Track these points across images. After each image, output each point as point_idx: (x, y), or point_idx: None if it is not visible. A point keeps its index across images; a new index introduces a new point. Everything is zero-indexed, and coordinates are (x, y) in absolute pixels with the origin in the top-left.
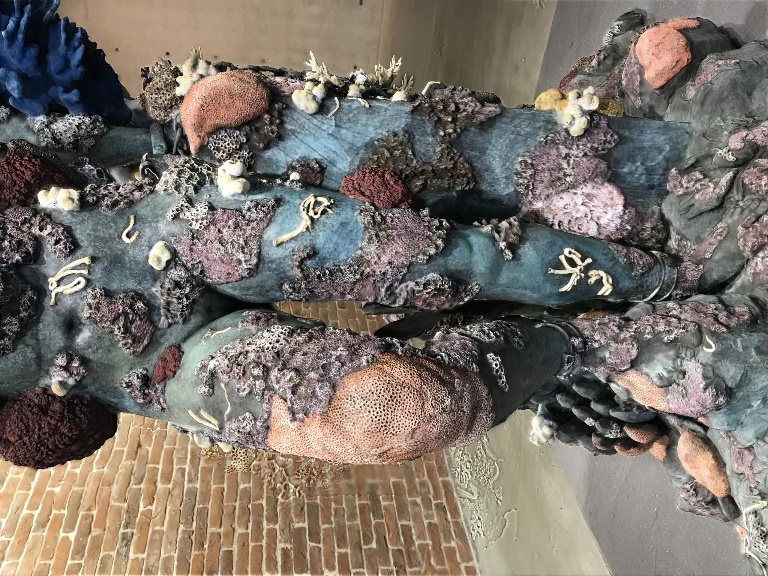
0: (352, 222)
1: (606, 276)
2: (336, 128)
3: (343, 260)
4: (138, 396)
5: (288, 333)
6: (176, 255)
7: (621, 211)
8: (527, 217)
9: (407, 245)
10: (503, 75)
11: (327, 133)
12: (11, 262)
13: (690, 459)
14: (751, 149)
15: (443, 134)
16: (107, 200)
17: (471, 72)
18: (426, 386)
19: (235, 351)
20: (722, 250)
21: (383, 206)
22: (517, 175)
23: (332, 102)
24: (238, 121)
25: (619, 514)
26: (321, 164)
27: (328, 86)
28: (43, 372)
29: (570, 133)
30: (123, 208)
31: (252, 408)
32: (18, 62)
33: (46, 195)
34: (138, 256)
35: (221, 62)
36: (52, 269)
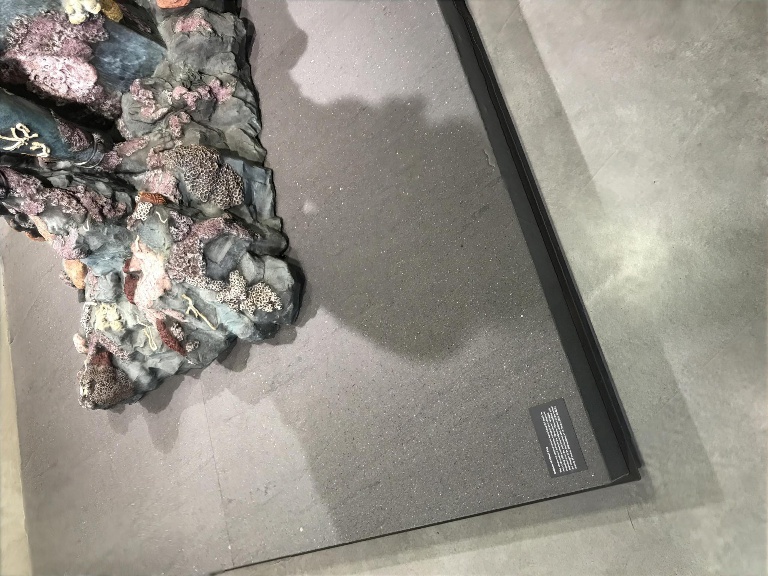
0: None
1: (46, 148)
2: None
3: None
4: None
5: None
6: None
7: (91, 86)
8: (8, 62)
9: None
10: None
11: None
12: None
13: (69, 263)
14: (183, 103)
15: None
16: None
17: None
18: None
19: None
20: (137, 156)
21: None
22: (10, 28)
23: None
24: None
25: (27, 256)
26: None
27: None
28: None
29: (69, 18)
30: None
31: None
32: None
33: None
34: None
35: None
36: None
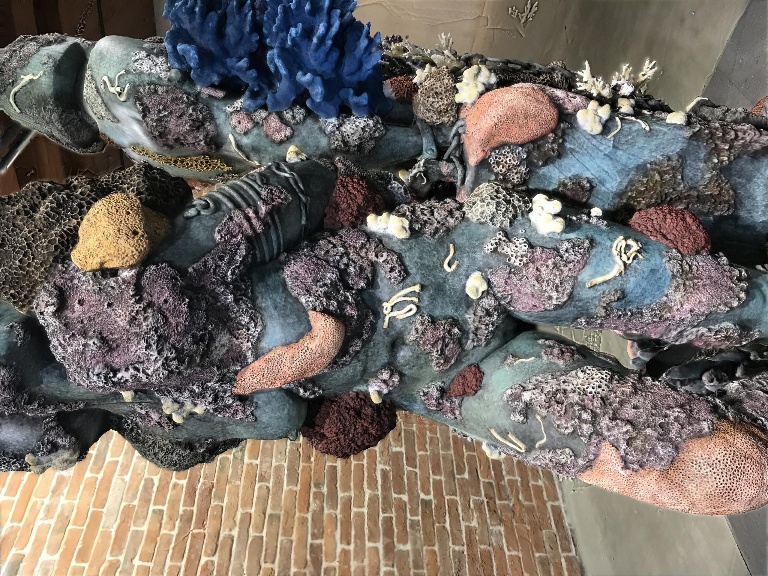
0: (661, 269)
1: None
2: (613, 149)
3: (647, 304)
4: (432, 404)
5: (609, 379)
6: (489, 285)
7: None
8: None
9: (711, 296)
10: (662, 25)
11: (603, 153)
12: (356, 288)
13: None
14: None
15: (717, 161)
16: (429, 227)
17: (618, 13)
18: (764, 457)
19: (551, 387)
20: None
21: (688, 253)
22: None
23: (614, 123)
24: (525, 140)
25: None
26: (591, 183)
27: (597, 97)
28: (362, 381)
29: None
30: (442, 236)
31: (573, 445)
32: (318, 65)
33: (376, 219)
34: (456, 284)
35: (474, 54)
36: (386, 294)
